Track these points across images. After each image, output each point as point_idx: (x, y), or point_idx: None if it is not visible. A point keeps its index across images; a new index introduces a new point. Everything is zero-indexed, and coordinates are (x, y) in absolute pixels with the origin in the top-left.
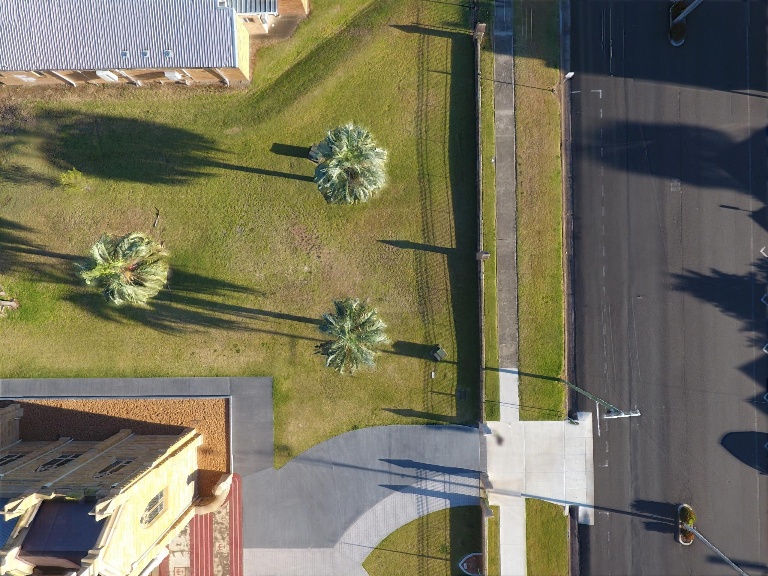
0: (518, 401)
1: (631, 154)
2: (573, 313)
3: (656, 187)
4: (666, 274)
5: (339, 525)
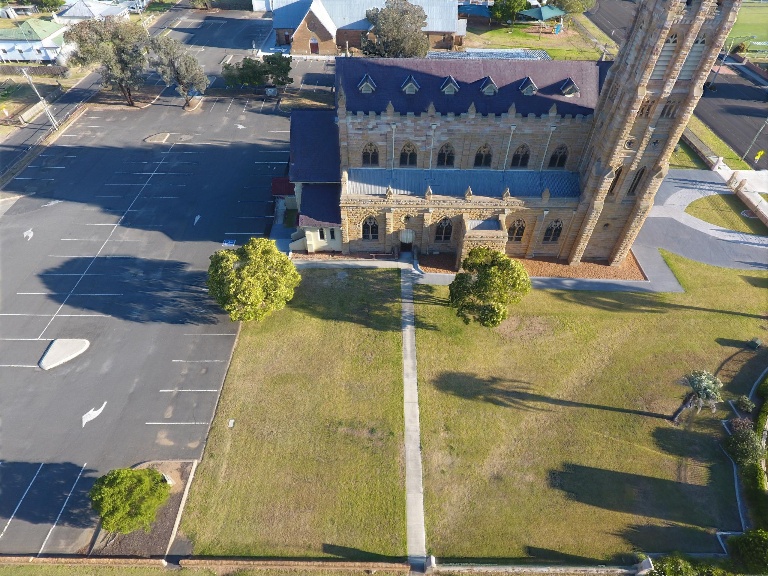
0: (725, 164)
1: (718, 110)
2: (729, 145)
3: (737, 116)
4: (763, 134)
5: (661, 198)
